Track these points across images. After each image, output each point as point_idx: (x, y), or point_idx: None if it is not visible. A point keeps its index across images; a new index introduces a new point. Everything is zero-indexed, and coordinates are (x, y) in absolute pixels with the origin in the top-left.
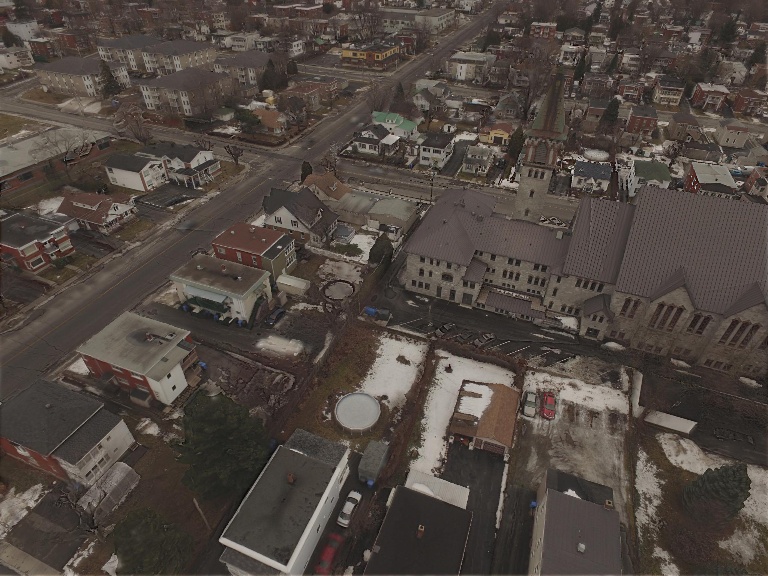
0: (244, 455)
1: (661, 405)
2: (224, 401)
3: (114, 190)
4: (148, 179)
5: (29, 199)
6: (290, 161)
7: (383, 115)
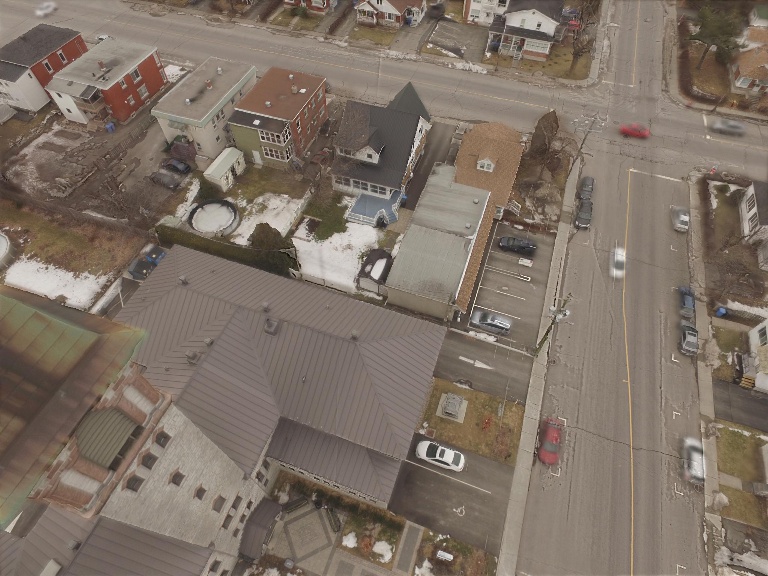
0: None
1: None
2: None
3: (460, 1)
4: (476, 7)
5: None
6: (633, 121)
7: None
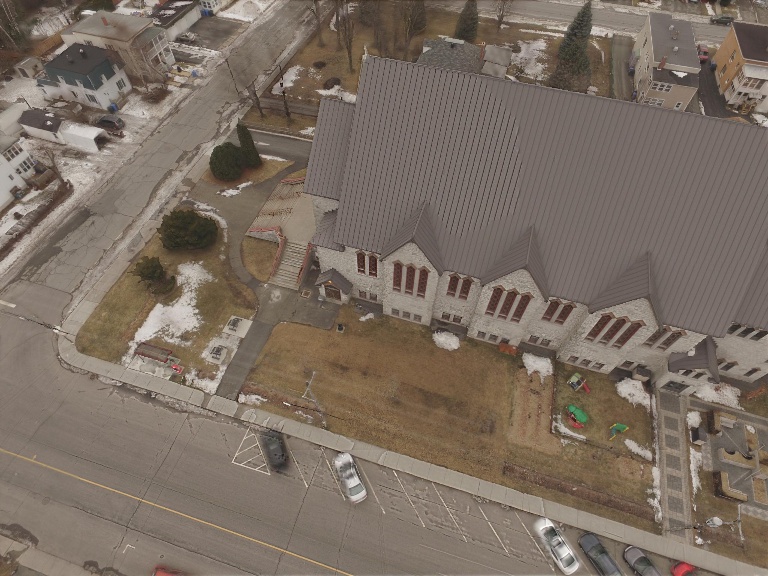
0: None
1: None
2: None
3: None
4: None
5: None
6: None
7: None
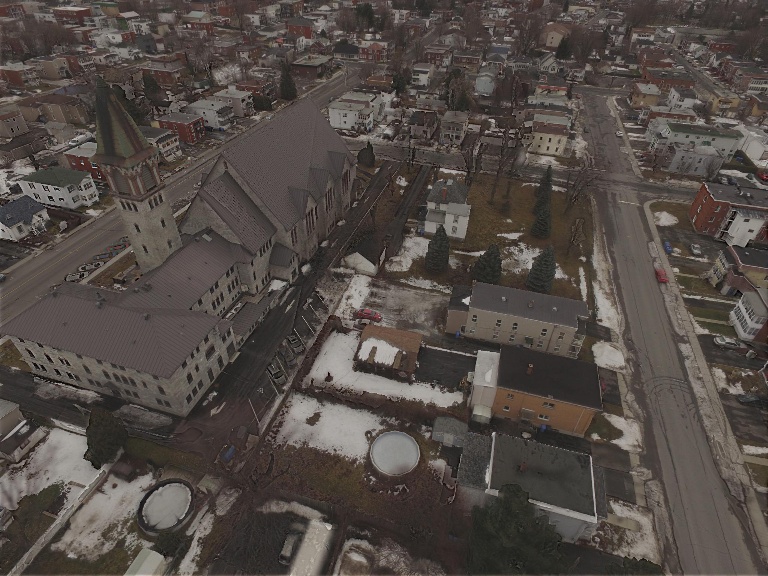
0: None
1: (376, 255)
2: None
3: None
4: None
5: None
6: None
7: None
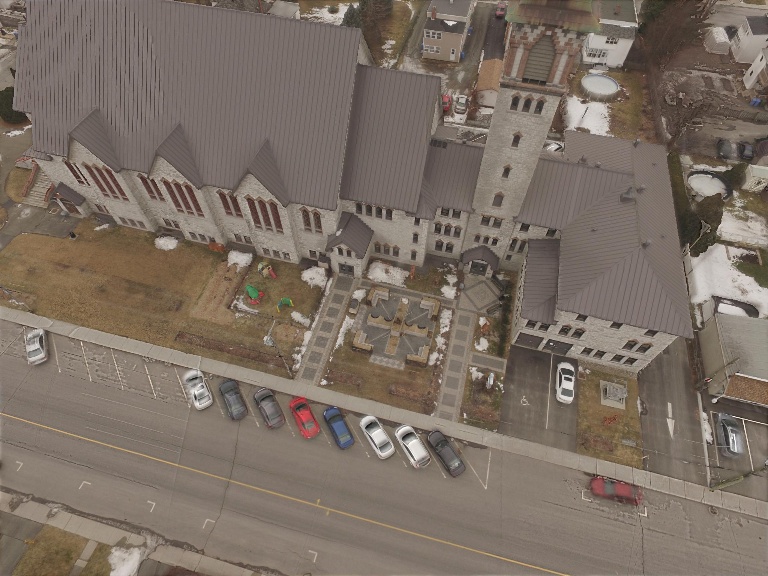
0: (654, 6)
1: None
2: None
3: None
4: None
5: None
6: None
7: None
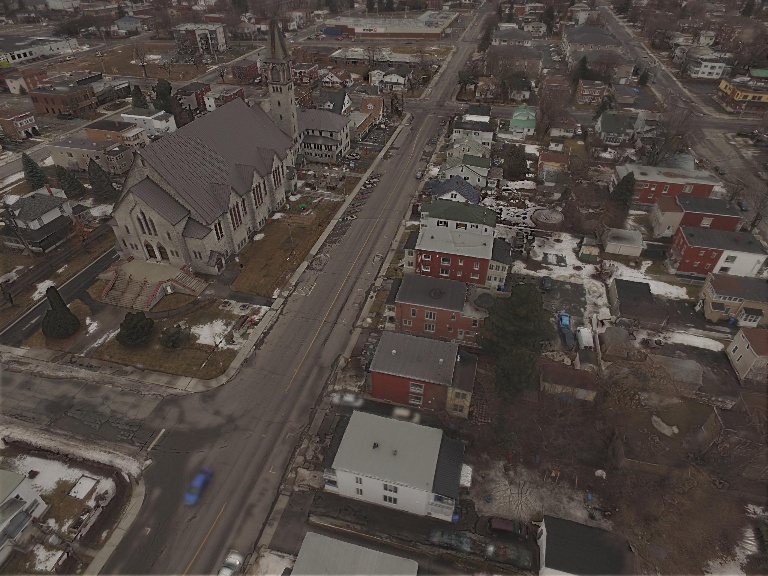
0: None
1: None
2: (165, 85)
3: None
4: (374, 79)
5: (353, 71)
6: (434, 106)
7: (522, 108)
